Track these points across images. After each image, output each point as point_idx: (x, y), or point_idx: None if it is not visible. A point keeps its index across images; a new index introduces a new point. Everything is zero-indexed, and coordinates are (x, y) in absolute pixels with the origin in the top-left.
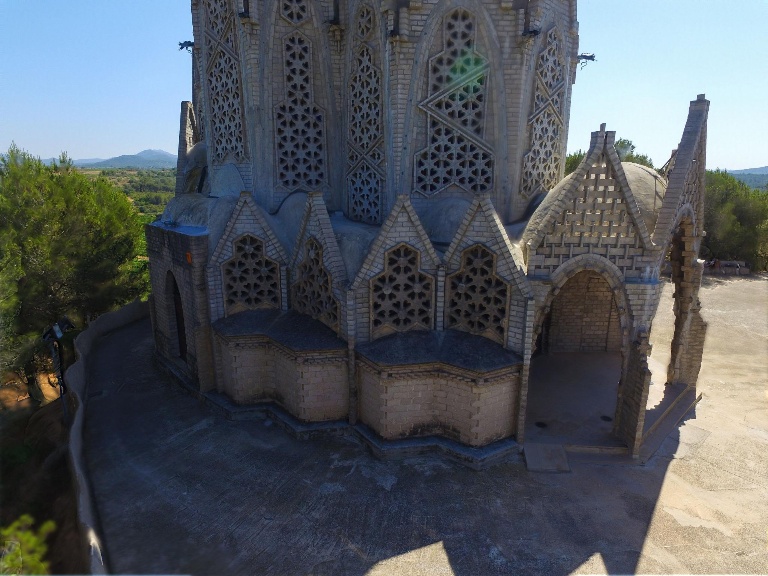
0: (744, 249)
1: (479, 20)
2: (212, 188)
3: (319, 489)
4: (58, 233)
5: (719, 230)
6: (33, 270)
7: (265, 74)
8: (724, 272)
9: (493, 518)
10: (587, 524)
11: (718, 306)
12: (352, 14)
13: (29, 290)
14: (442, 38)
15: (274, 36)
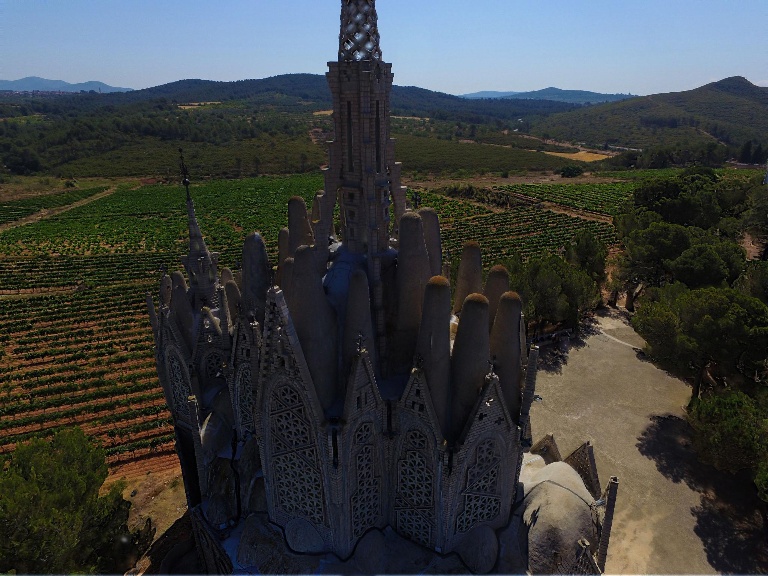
0: (571, 318)
1: (496, 440)
2: (295, 545)
3: None
4: None
5: (557, 313)
6: None
7: (346, 483)
8: (561, 341)
9: None
10: None
11: (571, 408)
12: (404, 427)
13: None
14: (476, 457)
15: (351, 457)
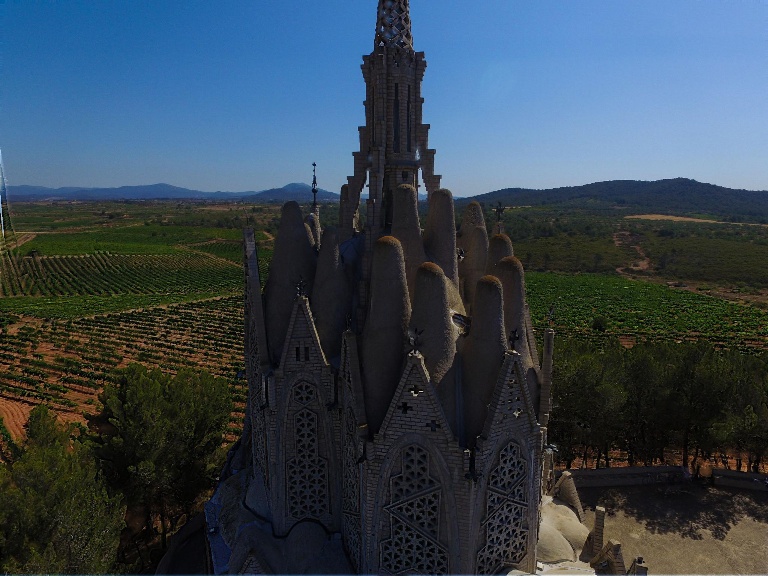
0: None
1: (431, 454)
2: (246, 498)
3: None
4: (165, 442)
5: None
6: (143, 481)
7: (280, 440)
8: None
9: None
10: None
11: None
12: (345, 404)
13: (139, 497)
14: (401, 464)
15: (288, 414)
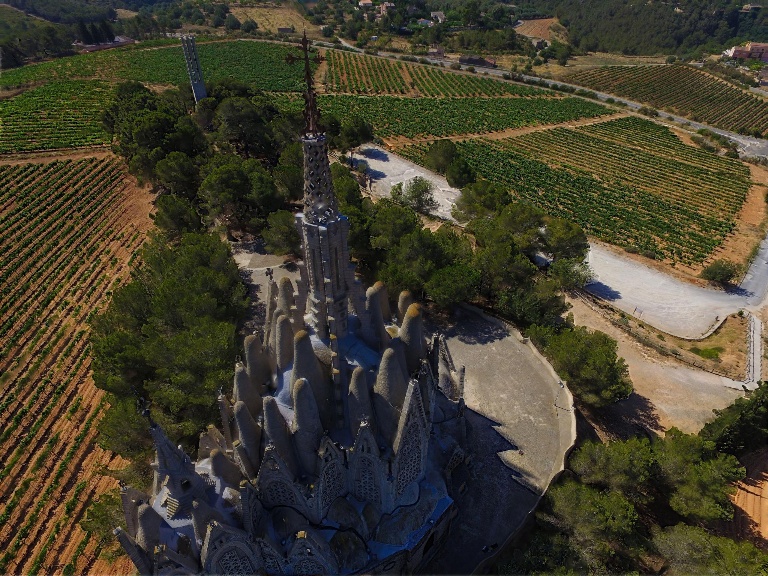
0: None
1: None
2: None
3: (487, 480)
4: None
5: (235, 277)
6: None
7: None
8: (245, 294)
9: (487, 442)
10: (484, 425)
11: None
12: None
13: None
14: None
15: None
